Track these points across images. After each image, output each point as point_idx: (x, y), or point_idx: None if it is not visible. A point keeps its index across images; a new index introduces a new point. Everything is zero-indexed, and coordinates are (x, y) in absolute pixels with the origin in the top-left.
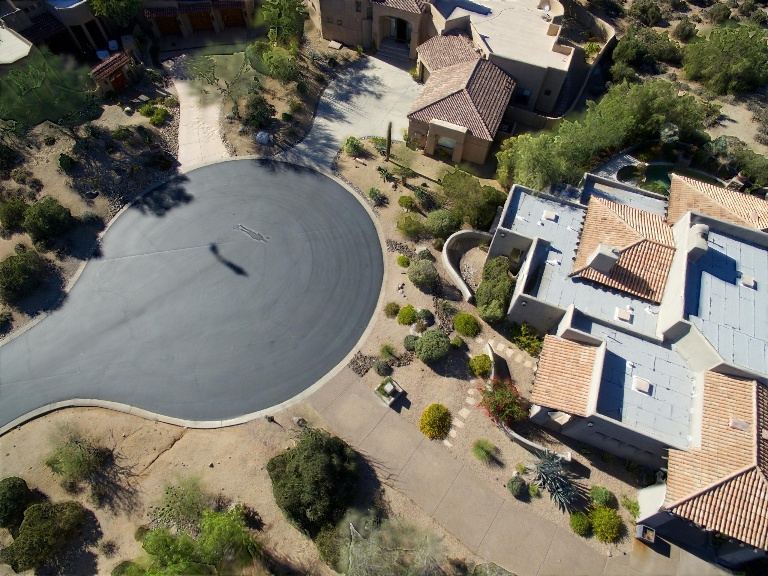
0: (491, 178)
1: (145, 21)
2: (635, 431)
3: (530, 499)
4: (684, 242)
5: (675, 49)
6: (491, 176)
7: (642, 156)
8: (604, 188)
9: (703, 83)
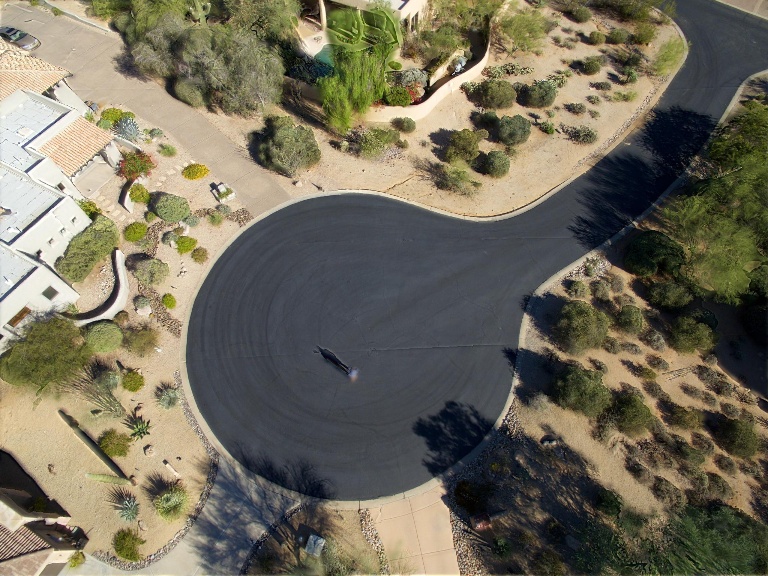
0: None
1: None
2: None
3: None
4: None
5: None
6: None
7: None
8: None
9: None
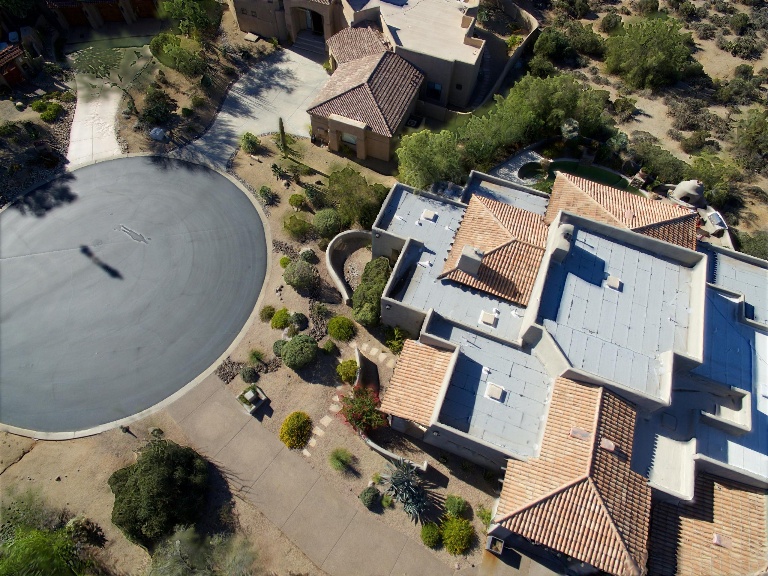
0: (395, 175)
1: (50, 12)
2: (475, 441)
3: (383, 510)
4: (550, 243)
5: (597, 42)
6: (395, 173)
7: (546, 152)
8: (490, 186)
9: (623, 77)
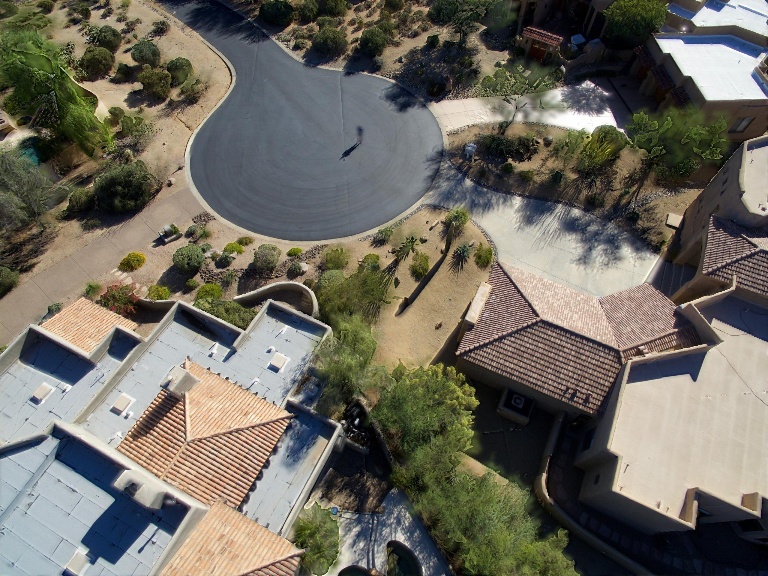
0: None
1: None
2: None
3: None
4: None
5: None
6: None
7: None
8: (317, 450)
9: None
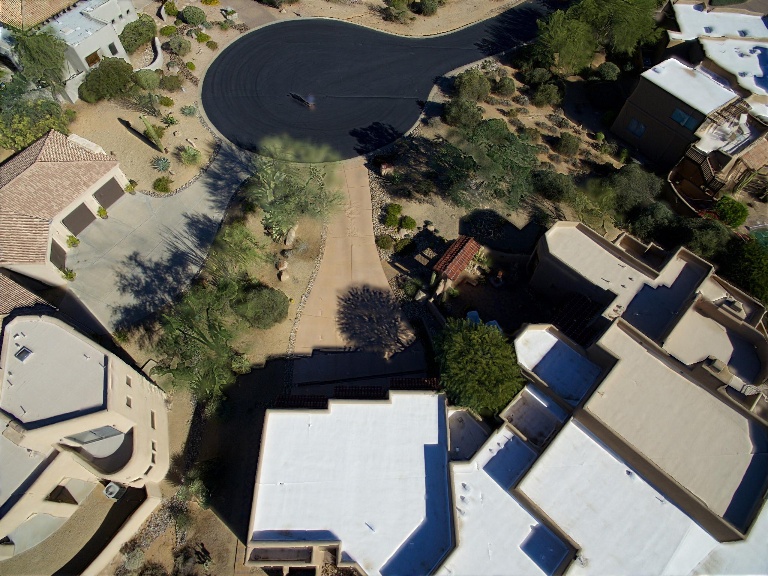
0: None
1: None
2: None
3: None
4: None
5: None
6: None
7: None
8: (6, 46)
9: None
